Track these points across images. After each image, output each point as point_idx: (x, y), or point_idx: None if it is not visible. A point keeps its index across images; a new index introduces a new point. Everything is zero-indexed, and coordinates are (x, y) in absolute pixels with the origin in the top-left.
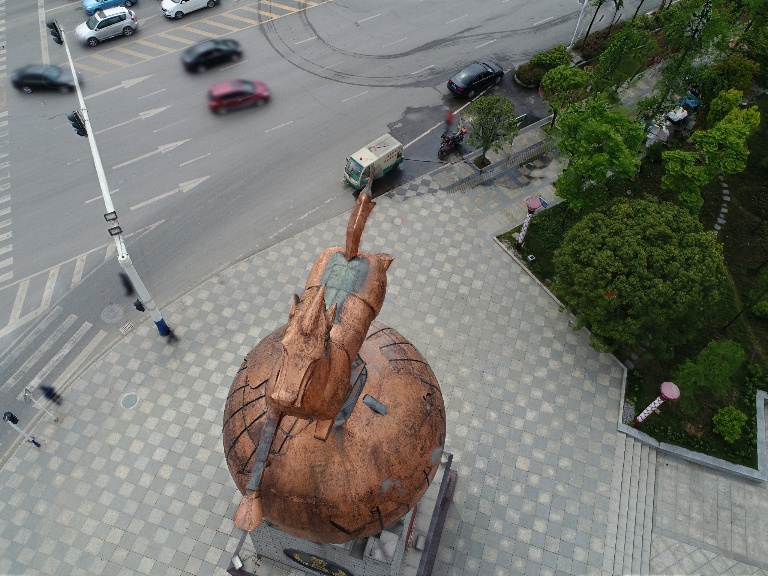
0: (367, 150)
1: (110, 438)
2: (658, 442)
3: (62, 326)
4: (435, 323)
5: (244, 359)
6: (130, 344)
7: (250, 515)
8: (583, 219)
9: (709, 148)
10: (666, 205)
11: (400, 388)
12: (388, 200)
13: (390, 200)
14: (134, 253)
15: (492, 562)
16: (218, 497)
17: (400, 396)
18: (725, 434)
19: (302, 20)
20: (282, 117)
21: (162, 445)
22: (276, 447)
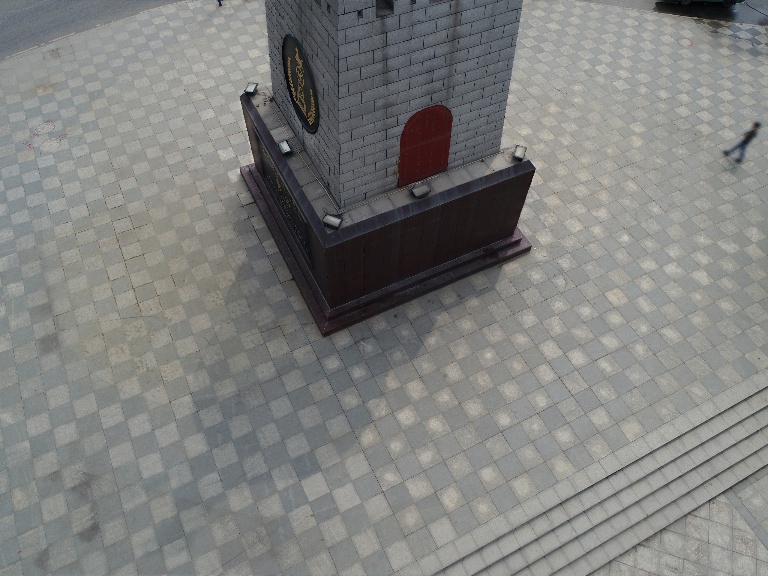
0: None
1: None
2: None
3: None
4: (639, 133)
5: None
6: None
7: None
8: None
9: None
10: None
11: None
12: (692, 23)
13: (694, 24)
14: None
15: (489, 340)
16: None
17: None
18: None
19: None
20: None
21: None
22: None
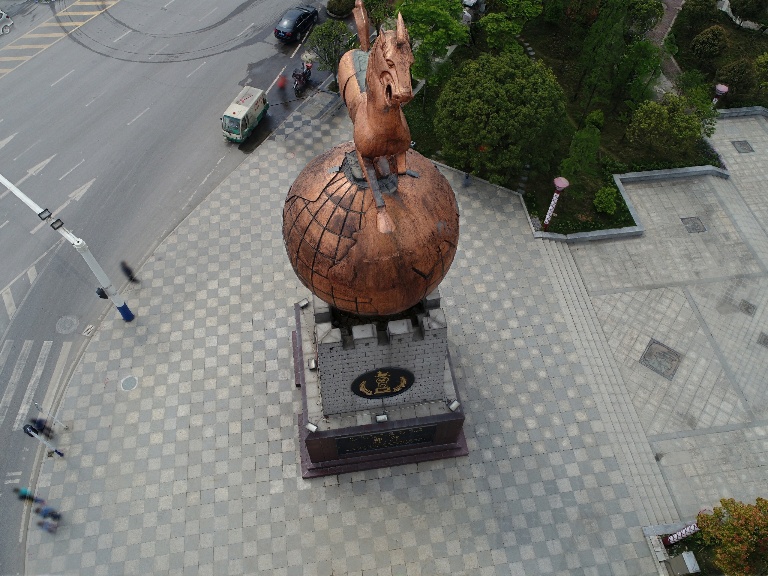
0: (236, 105)
1: (128, 419)
2: (565, 235)
3: (22, 354)
4: None
5: (287, 200)
6: (101, 340)
7: (388, 222)
8: (445, 87)
9: (513, 1)
10: (500, 56)
11: (418, 161)
12: (272, 142)
13: (274, 142)
14: (58, 268)
15: (492, 362)
16: (254, 418)
17: (421, 165)
18: (606, 209)
19: (108, 20)
20: (137, 107)
21: (181, 403)
22: (356, 226)
